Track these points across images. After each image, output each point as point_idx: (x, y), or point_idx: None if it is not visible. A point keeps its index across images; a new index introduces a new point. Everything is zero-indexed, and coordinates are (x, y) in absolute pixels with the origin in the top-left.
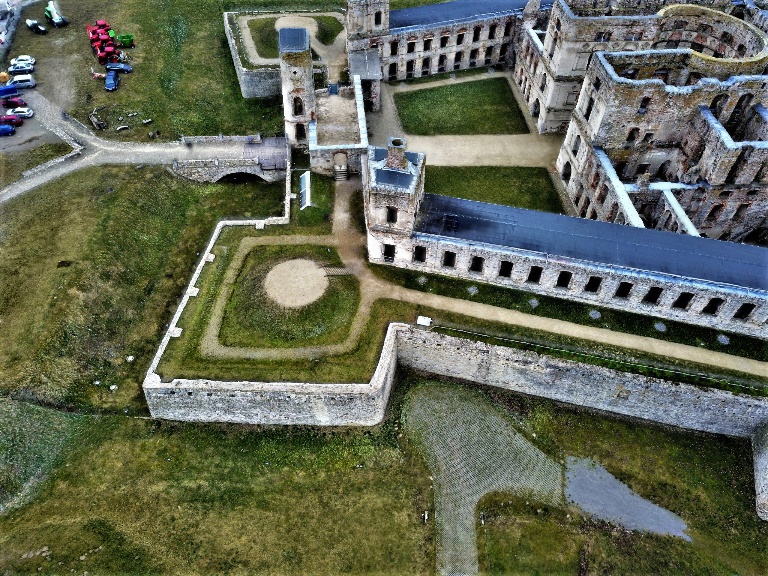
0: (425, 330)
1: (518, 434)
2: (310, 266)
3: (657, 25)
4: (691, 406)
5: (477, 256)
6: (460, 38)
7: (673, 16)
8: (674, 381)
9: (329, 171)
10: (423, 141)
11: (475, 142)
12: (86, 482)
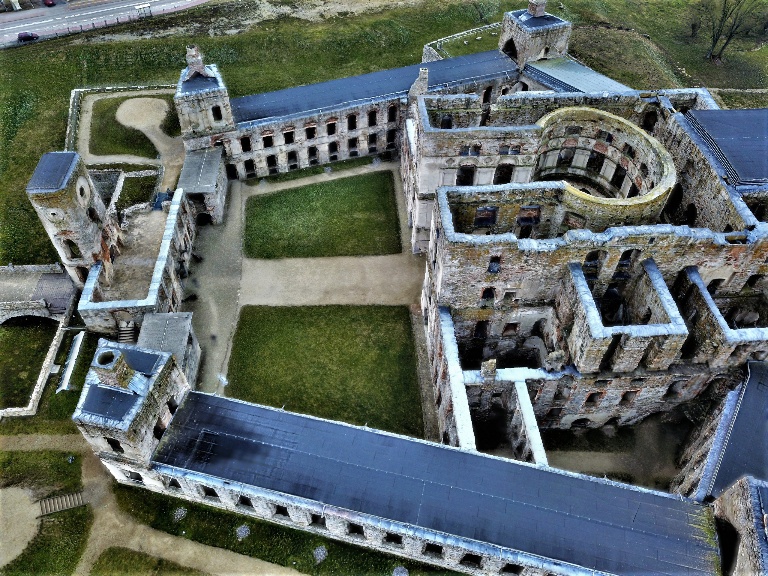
0: None
1: None
2: (23, 500)
3: (537, 137)
4: None
5: None
6: (331, 127)
7: (562, 121)
8: None
9: (112, 329)
10: (264, 267)
11: (328, 268)
12: None
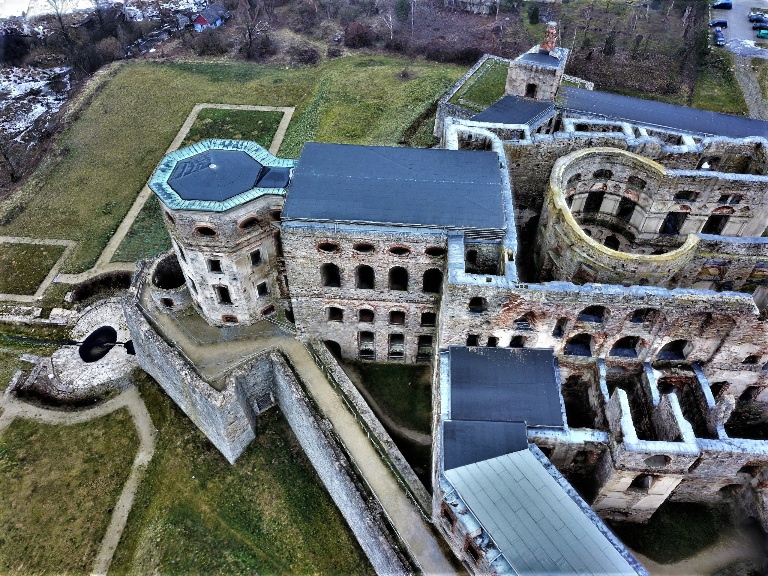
0: None
1: None
2: None
3: None
4: None
5: None
6: None
7: None
8: None
9: None
10: None
11: None
12: None
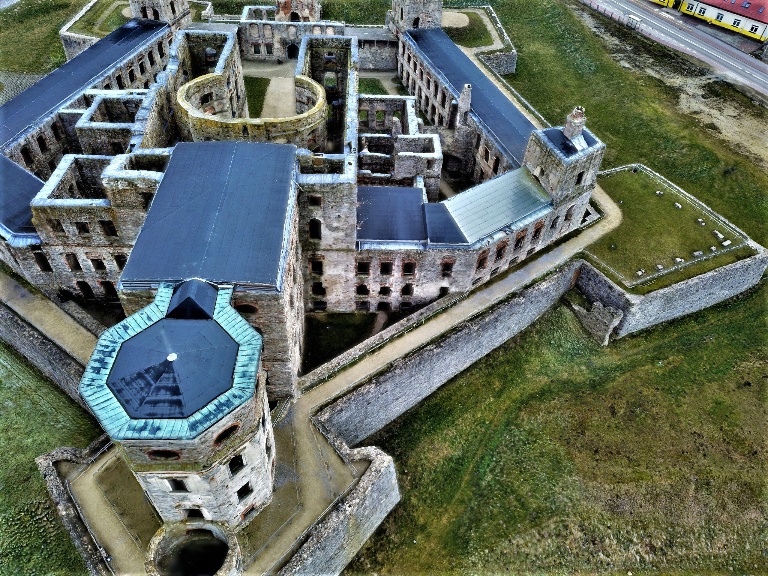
0: None
1: None
2: None
3: None
4: None
5: None
6: None
7: None
8: None
9: None
10: None
11: None
12: None
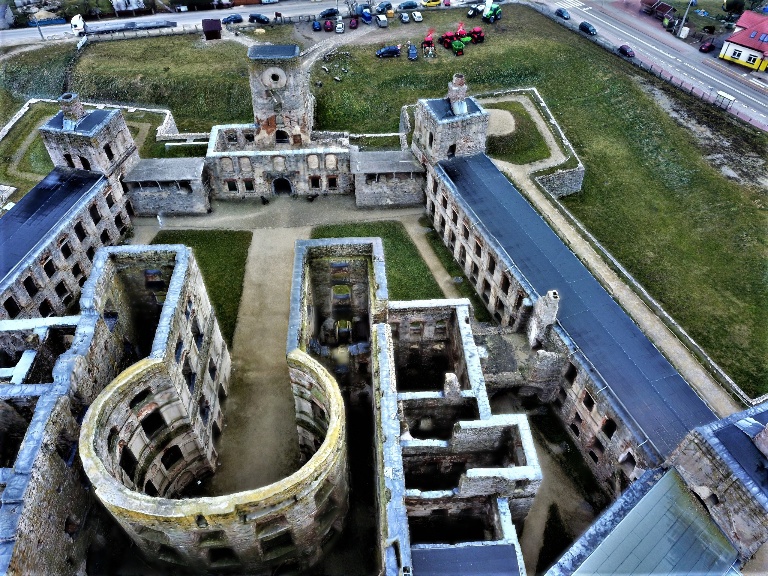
0: (1, 208)
1: None
2: None
3: None
4: None
5: None
6: None
7: None
8: None
9: None
10: None
11: None
12: (15, 111)
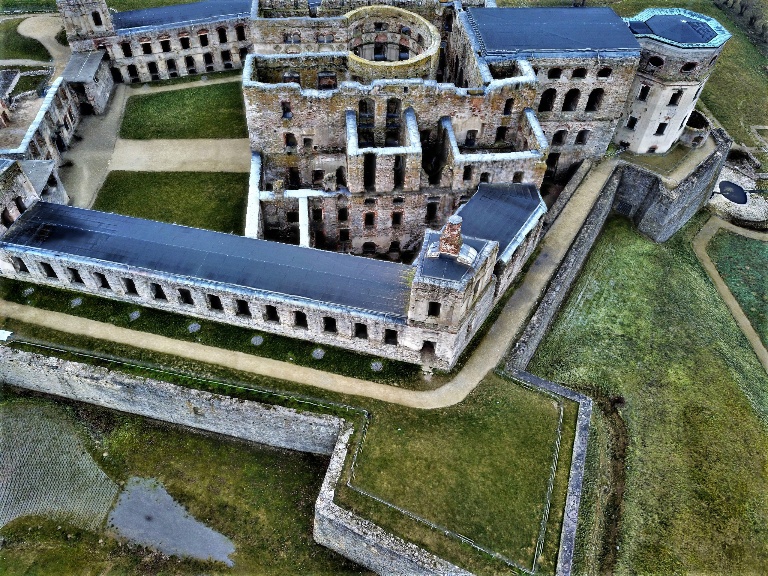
0: (0, 345)
1: (86, 454)
2: None
3: (345, 27)
4: (262, 424)
5: (69, 267)
6: (204, 39)
7: (370, 17)
8: (241, 398)
9: None
10: (134, 145)
11: (189, 146)
12: None
